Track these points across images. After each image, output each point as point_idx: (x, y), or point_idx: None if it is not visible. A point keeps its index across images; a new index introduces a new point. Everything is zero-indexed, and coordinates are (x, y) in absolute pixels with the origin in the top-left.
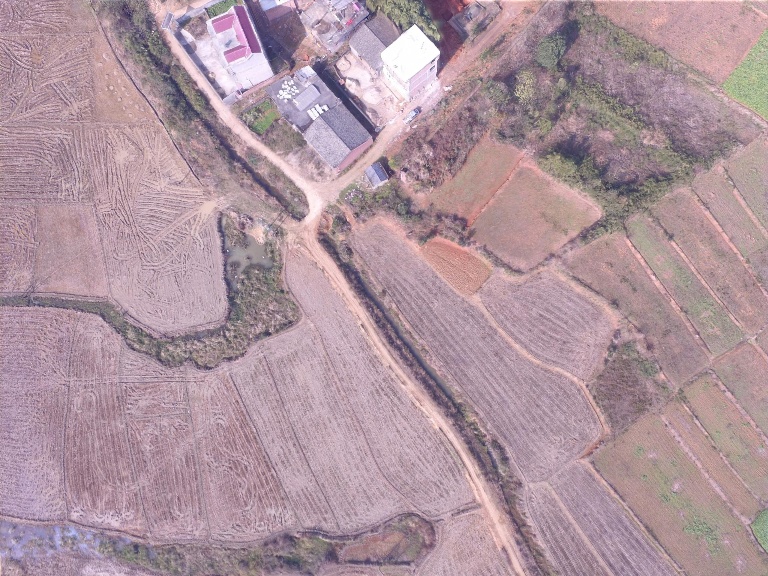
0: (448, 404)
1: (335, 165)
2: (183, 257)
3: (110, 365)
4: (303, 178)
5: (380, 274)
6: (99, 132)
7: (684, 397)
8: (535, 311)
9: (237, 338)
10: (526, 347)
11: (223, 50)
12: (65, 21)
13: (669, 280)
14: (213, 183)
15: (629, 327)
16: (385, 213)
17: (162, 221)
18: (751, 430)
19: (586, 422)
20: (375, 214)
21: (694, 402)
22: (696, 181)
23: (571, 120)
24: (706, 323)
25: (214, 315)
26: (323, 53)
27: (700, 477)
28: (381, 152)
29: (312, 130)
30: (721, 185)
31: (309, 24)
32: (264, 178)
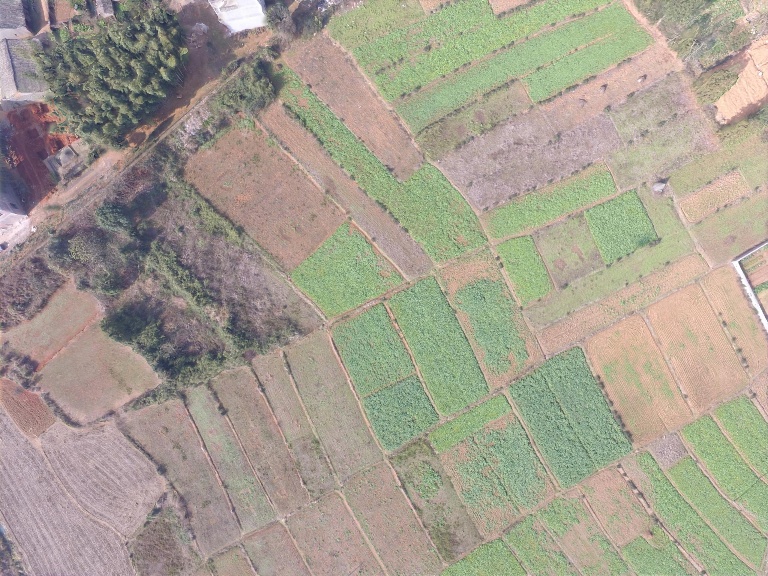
0: None
1: None
2: None
3: None
4: None
5: None
6: None
7: (213, 566)
8: (92, 463)
9: None
10: (77, 497)
11: None
12: None
13: (217, 453)
14: None
15: (174, 492)
16: None
17: None
18: None
19: None
20: None
21: (221, 572)
22: (257, 361)
23: (149, 282)
24: (243, 500)
25: None
26: None
27: None
28: None
29: None
30: (280, 369)
31: None
32: None
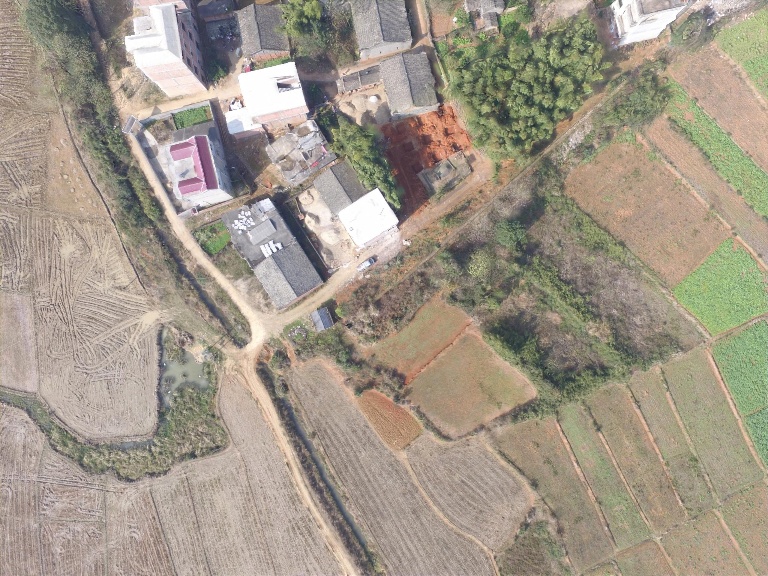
0: (360, 552)
1: (281, 307)
2: (118, 365)
3: (30, 463)
4: (249, 306)
5: (313, 415)
6: (47, 221)
7: None
8: (458, 476)
9: (162, 454)
10: (443, 510)
11: (179, 179)
12: (25, 97)
13: (590, 469)
14: (158, 295)
15: (544, 507)
16: (326, 357)
17: (101, 324)
18: None
19: None
20: (316, 355)
21: None
22: (633, 377)
23: (523, 296)
24: (617, 516)
25: (142, 428)
26: (287, 183)
27: None
28: (331, 294)
29: (262, 267)
30: (656, 385)
31: (274, 158)
32: (211, 297)
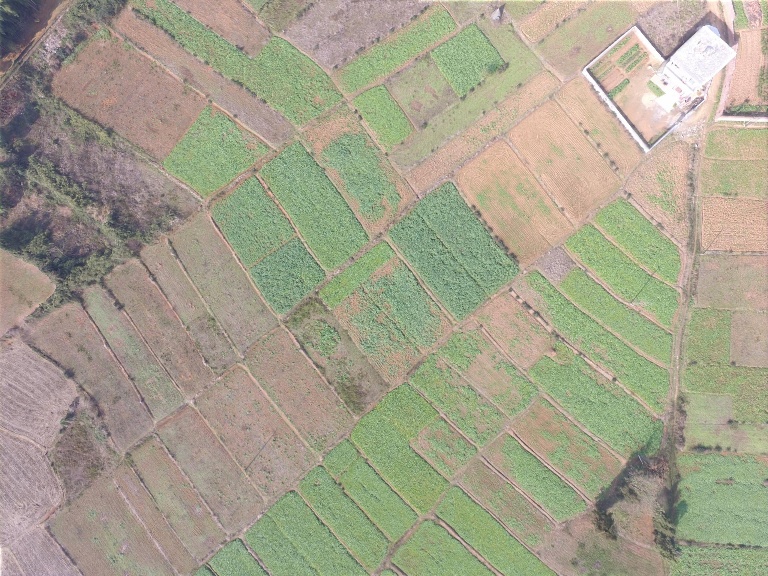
0: None
1: None
2: None
3: None
4: None
5: None
6: None
7: (131, 461)
8: (5, 381)
9: None
10: None
11: None
12: None
13: (120, 348)
14: None
15: (85, 394)
16: None
17: None
18: (190, 491)
19: (49, 487)
20: None
21: (140, 465)
22: (145, 253)
23: (34, 197)
24: (151, 389)
25: None
26: None
27: (146, 538)
28: None
29: None
30: (168, 256)
31: None
32: None
